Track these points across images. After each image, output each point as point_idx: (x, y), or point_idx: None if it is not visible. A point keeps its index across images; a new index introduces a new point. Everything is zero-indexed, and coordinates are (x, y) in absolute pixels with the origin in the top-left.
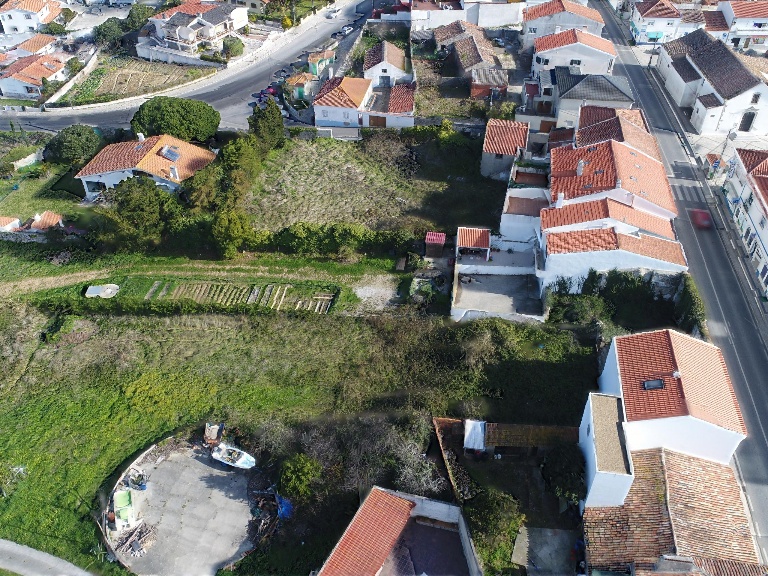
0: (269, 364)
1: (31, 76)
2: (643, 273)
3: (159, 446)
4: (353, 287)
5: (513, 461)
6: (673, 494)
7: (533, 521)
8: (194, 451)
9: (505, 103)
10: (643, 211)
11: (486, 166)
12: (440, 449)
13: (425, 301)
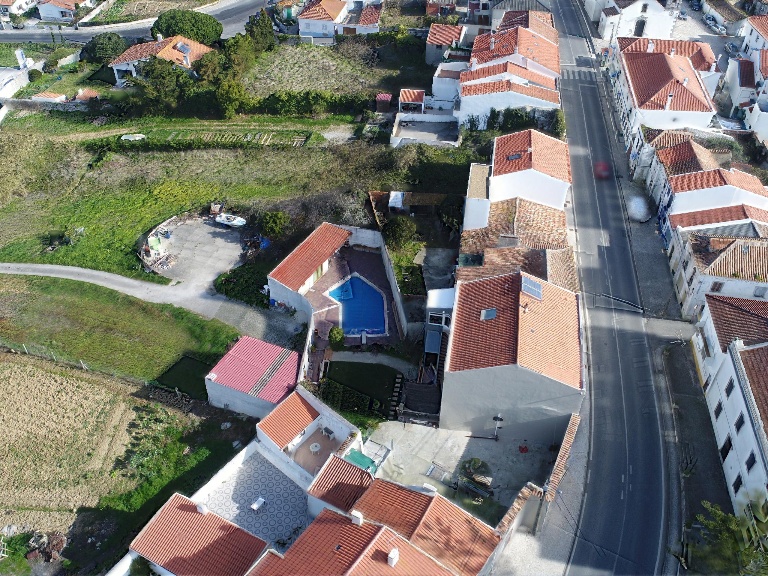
0: (257, 174)
1: (65, 2)
2: (529, 110)
3: (179, 217)
4: (322, 132)
5: (423, 217)
6: (519, 218)
7: (431, 245)
8: (203, 220)
9: (451, 16)
10: (535, 72)
11: (429, 56)
12: (372, 206)
13: (373, 136)
